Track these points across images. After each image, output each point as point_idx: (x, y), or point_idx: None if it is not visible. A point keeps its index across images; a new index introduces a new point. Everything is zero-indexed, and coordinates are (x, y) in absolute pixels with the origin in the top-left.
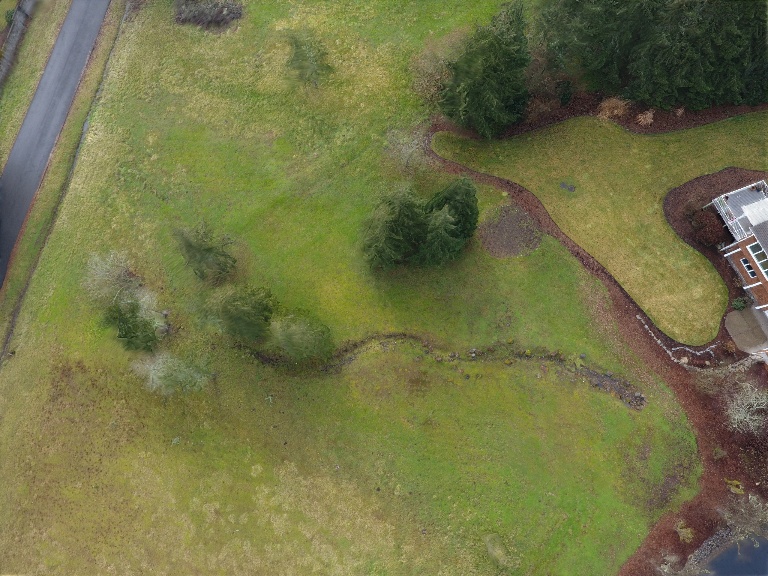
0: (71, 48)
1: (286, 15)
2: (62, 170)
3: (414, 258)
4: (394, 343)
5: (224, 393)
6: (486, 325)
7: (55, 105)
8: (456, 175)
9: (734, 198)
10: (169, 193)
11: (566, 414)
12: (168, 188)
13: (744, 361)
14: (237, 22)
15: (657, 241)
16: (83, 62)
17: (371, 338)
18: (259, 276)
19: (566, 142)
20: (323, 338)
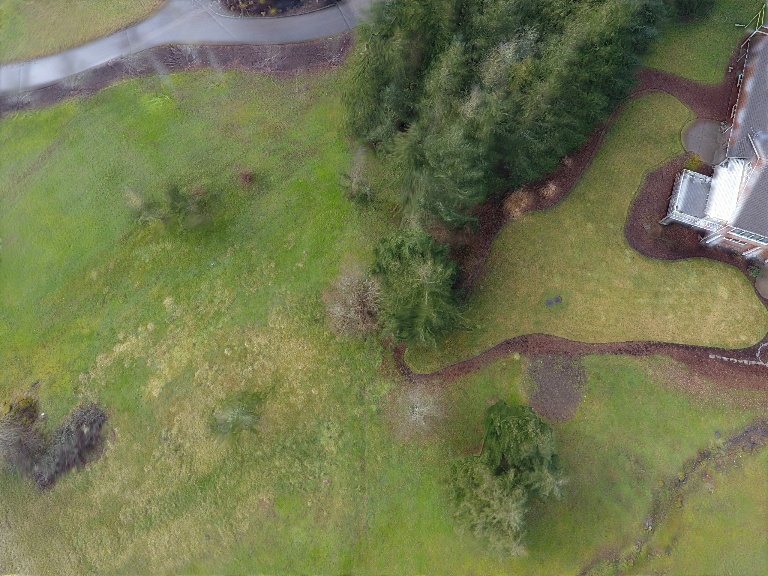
0: None
1: (149, 372)
2: None
3: None
4: None
5: None
6: (629, 490)
7: None
8: (462, 378)
9: (678, 200)
10: None
11: (762, 501)
12: None
13: None
14: (107, 425)
15: (657, 279)
16: None
17: None
18: None
19: (512, 263)
20: None
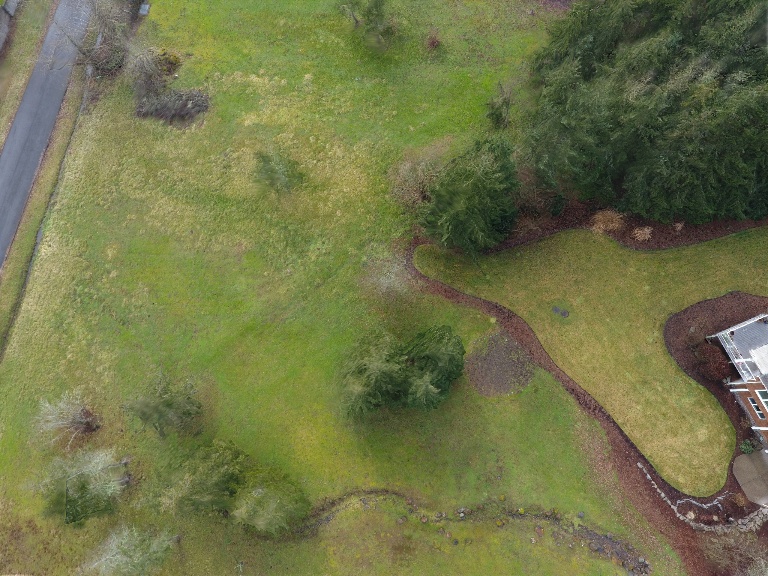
0: (23, 146)
1: (256, 108)
2: (13, 288)
3: (395, 404)
4: (375, 500)
5: (189, 559)
6: (475, 478)
7: (5, 213)
8: (440, 297)
9: (740, 332)
10: (130, 316)
11: None
12: (128, 311)
13: (755, 516)
14: (203, 116)
15: (658, 375)
16: (36, 162)
17: (350, 494)
18: (227, 418)
19: (558, 259)
20: (295, 511)
